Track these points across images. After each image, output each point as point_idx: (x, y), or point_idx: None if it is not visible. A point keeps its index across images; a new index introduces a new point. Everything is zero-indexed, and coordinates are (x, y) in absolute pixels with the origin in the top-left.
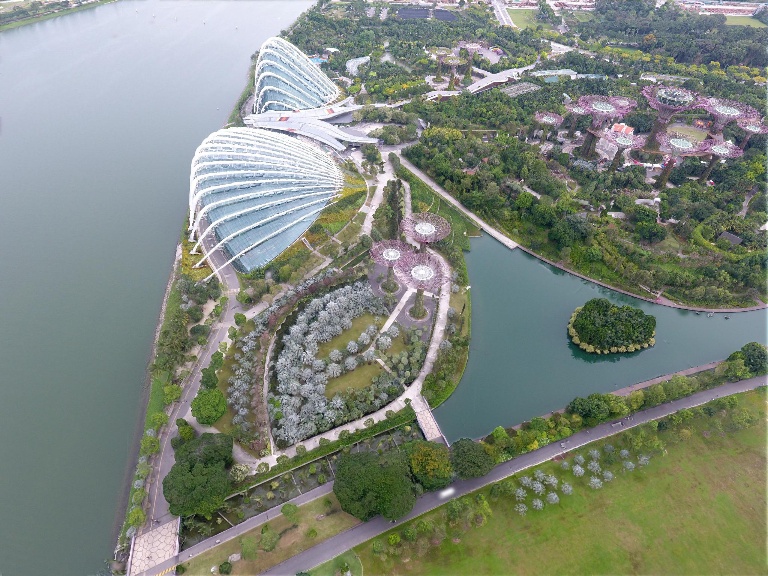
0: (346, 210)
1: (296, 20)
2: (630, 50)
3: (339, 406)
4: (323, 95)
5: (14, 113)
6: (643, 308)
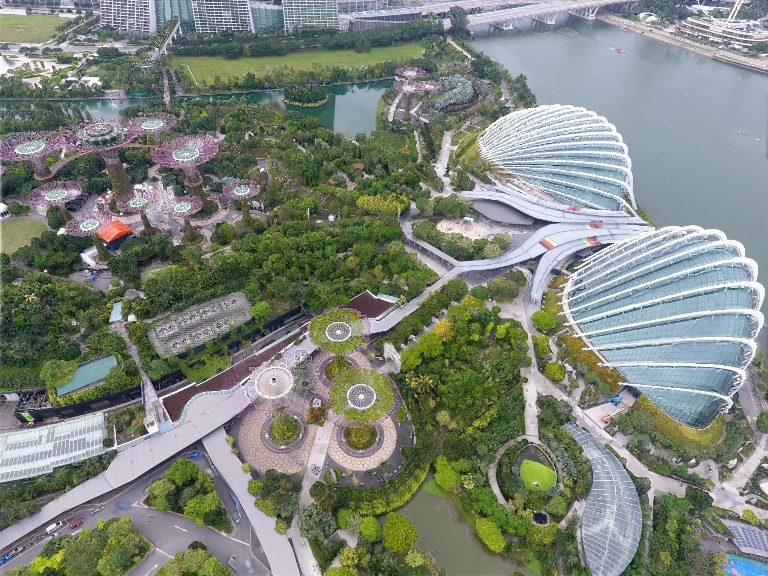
0: None
1: None
2: None
3: None
4: None
5: None
6: None
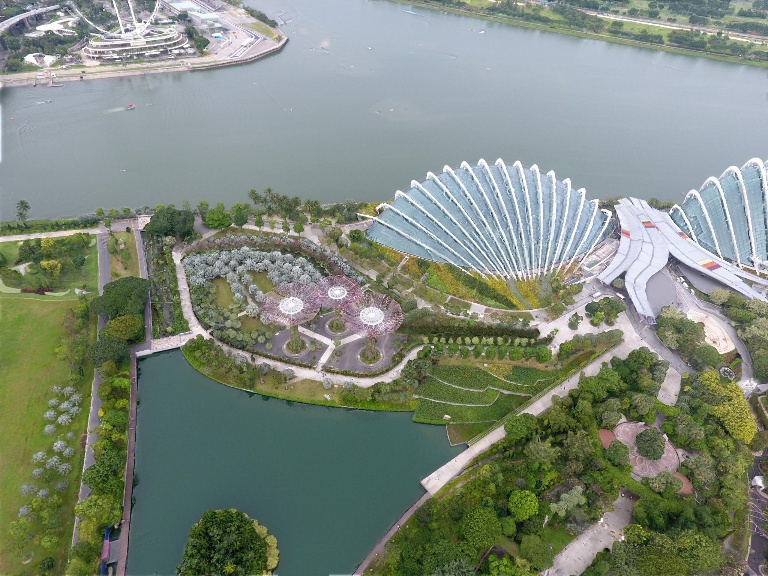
0: (466, 288)
1: None
2: None
3: (197, 282)
4: (762, 257)
5: (586, 103)
6: None
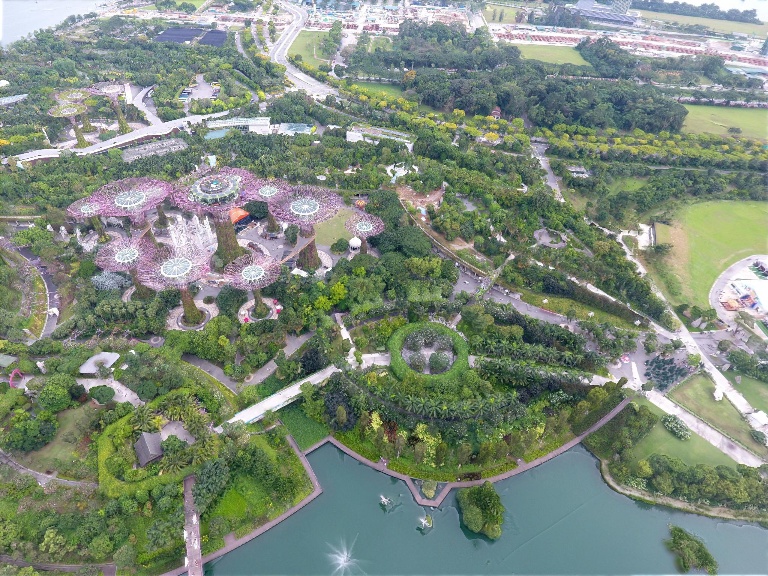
0: None
1: (15, 40)
2: (390, 89)
3: None
4: None
5: None
6: None
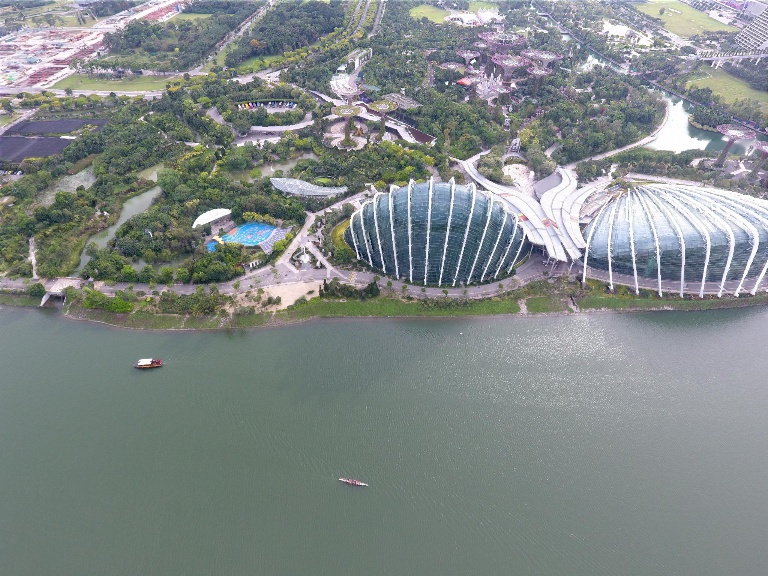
0: None
1: None
2: (257, 59)
3: None
4: None
5: None
6: (672, 115)
